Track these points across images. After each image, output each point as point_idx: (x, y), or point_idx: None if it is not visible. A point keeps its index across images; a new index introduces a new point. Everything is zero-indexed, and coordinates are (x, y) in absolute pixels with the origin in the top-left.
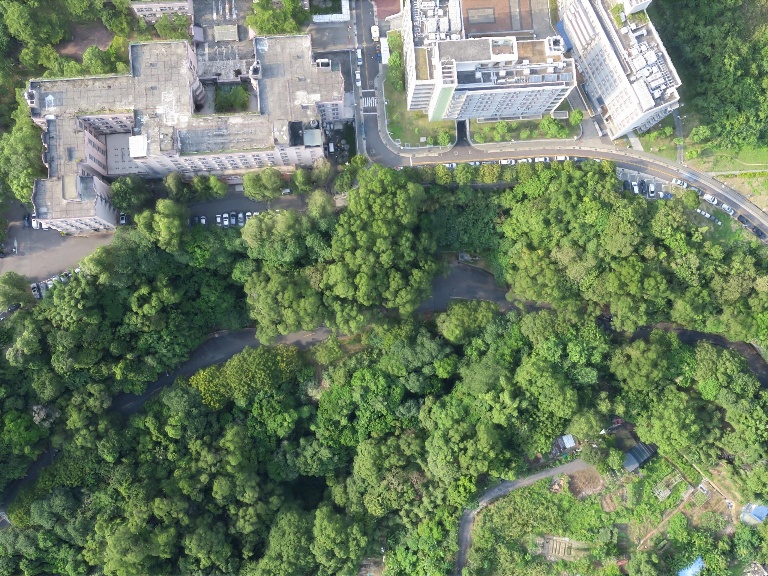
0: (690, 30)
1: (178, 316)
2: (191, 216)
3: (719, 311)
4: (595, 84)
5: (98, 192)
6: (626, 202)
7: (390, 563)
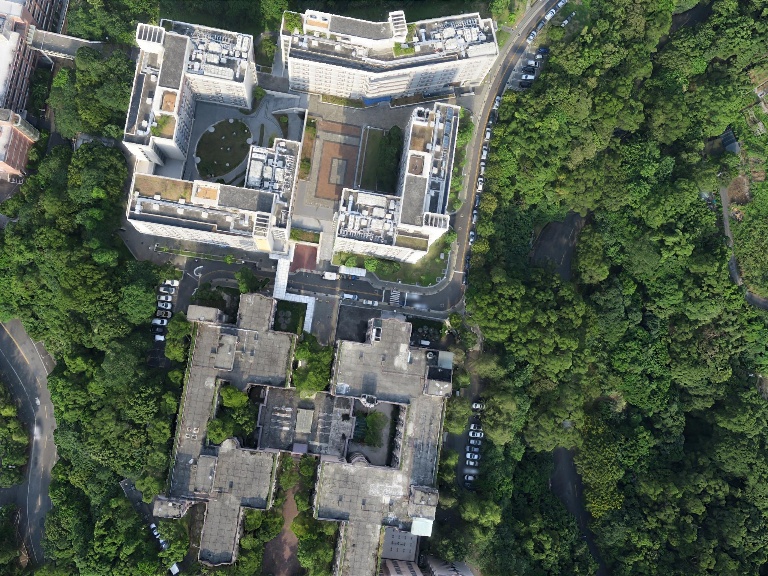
0: None
1: (545, 518)
2: None
3: (645, 38)
4: (434, 86)
5: (452, 573)
6: (551, 91)
7: (767, 372)
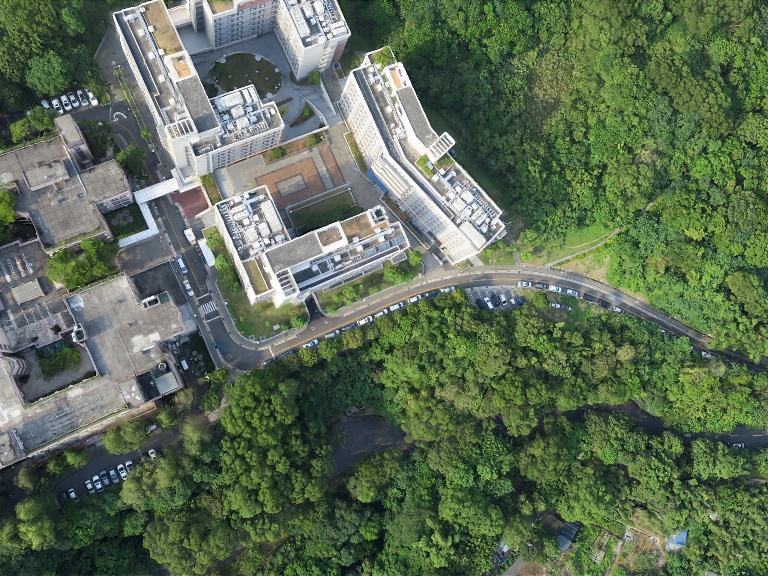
0: (488, 143)
1: None
2: (57, 494)
3: (595, 387)
4: (422, 222)
5: None
6: (487, 327)
7: None
